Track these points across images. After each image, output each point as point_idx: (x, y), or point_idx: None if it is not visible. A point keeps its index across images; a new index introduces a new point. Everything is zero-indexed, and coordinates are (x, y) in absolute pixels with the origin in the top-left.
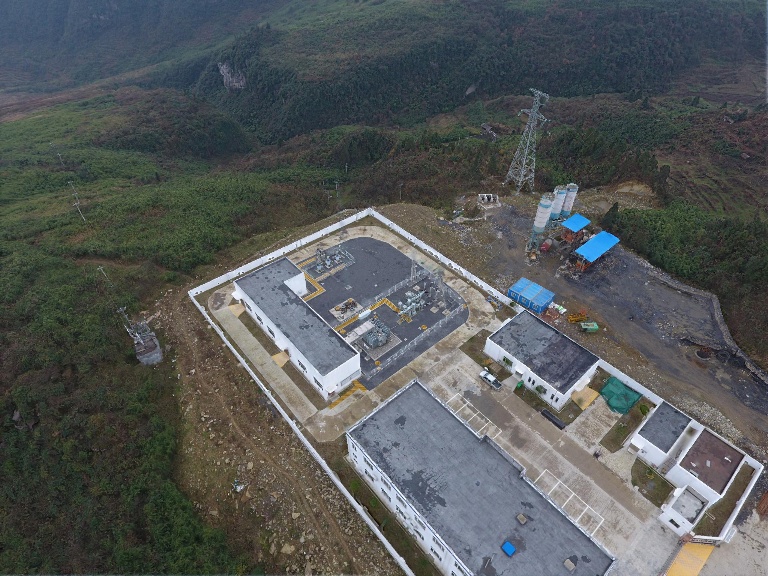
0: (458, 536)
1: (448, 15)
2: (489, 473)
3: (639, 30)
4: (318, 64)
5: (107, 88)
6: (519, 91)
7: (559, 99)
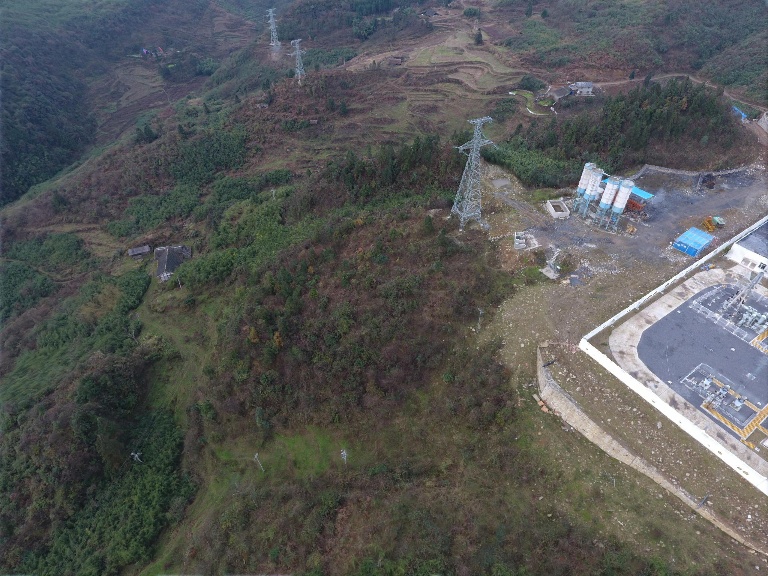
0: None
1: None
2: None
3: (7, 77)
4: None
5: None
6: None
7: (47, 187)
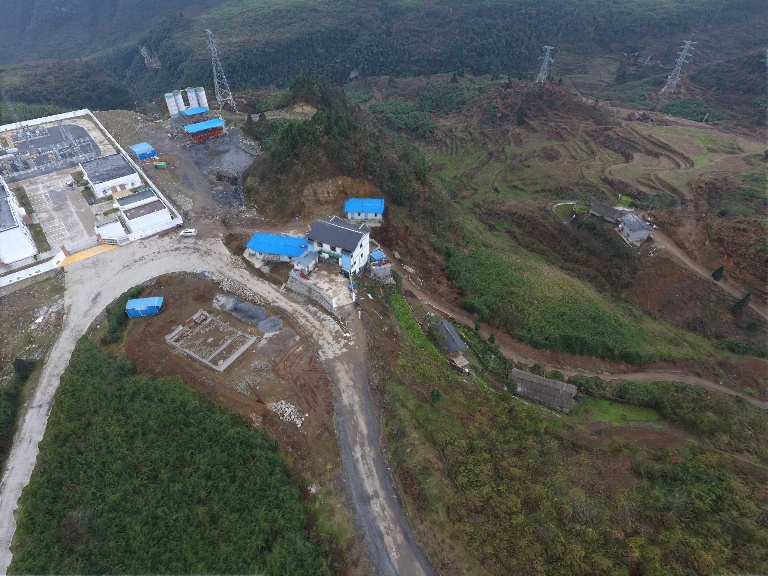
0: None
1: (337, 8)
2: None
3: (497, 25)
4: None
5: None
6: (395, 76)
7: None
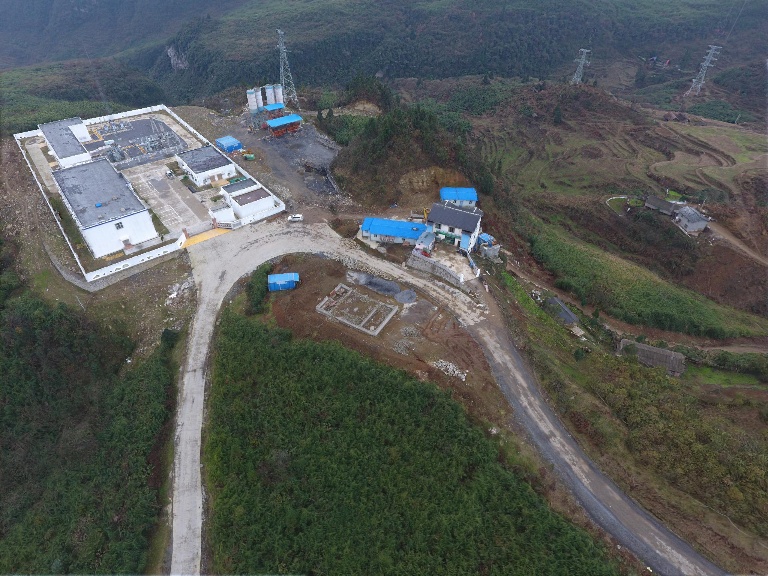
0: (78, 202)
1: (362, 12)
2: (114, 186)
3: (519, 29)
4: (243, 47)
5: None
6: None
7: None
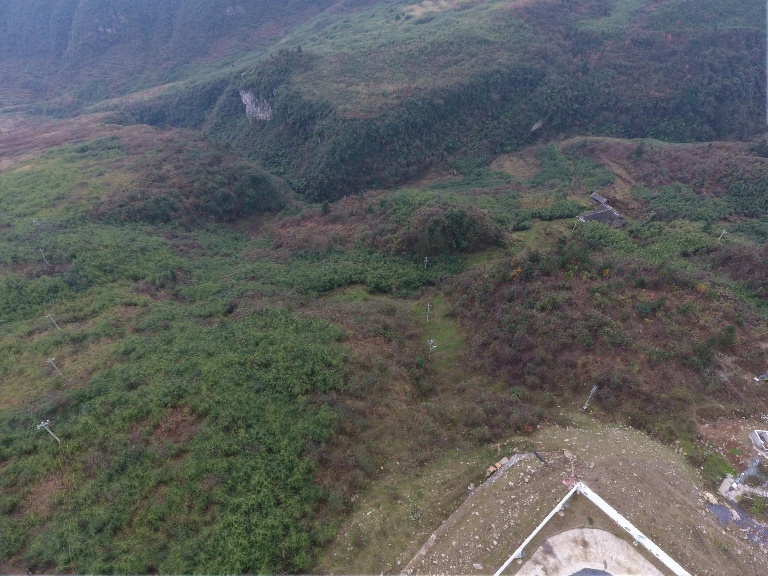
0: None
1: (511, 37)
2: None
3: (743, 57)
4: (361, 97)
5: (112, 119)
6: (595, 128)
7: (653, 142)
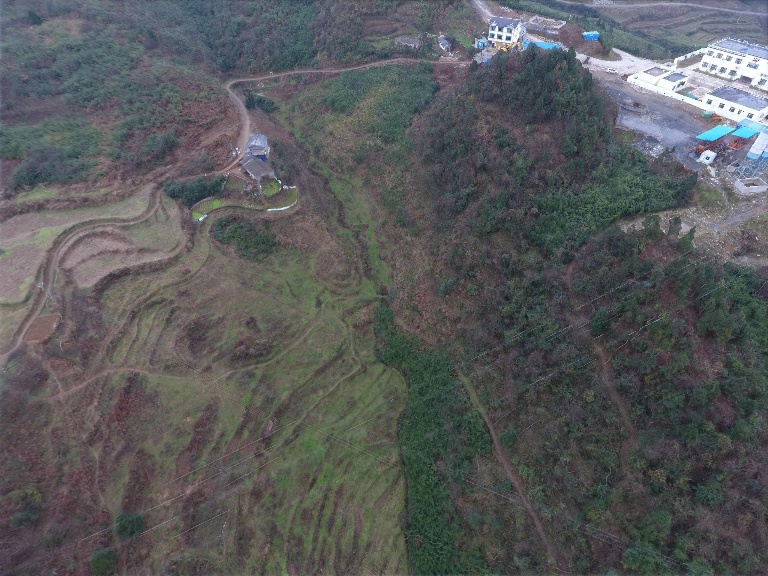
0: None
1: None
2: None
3: None
4: None
5: None
6: None
7: None
